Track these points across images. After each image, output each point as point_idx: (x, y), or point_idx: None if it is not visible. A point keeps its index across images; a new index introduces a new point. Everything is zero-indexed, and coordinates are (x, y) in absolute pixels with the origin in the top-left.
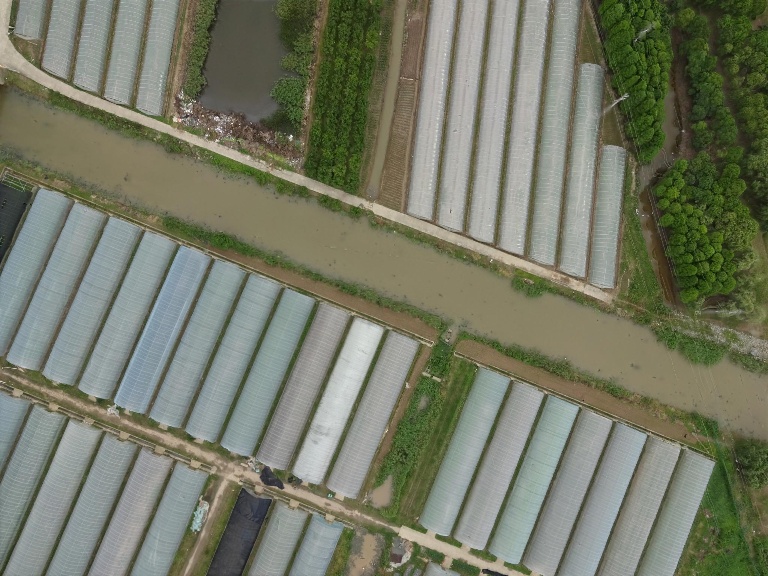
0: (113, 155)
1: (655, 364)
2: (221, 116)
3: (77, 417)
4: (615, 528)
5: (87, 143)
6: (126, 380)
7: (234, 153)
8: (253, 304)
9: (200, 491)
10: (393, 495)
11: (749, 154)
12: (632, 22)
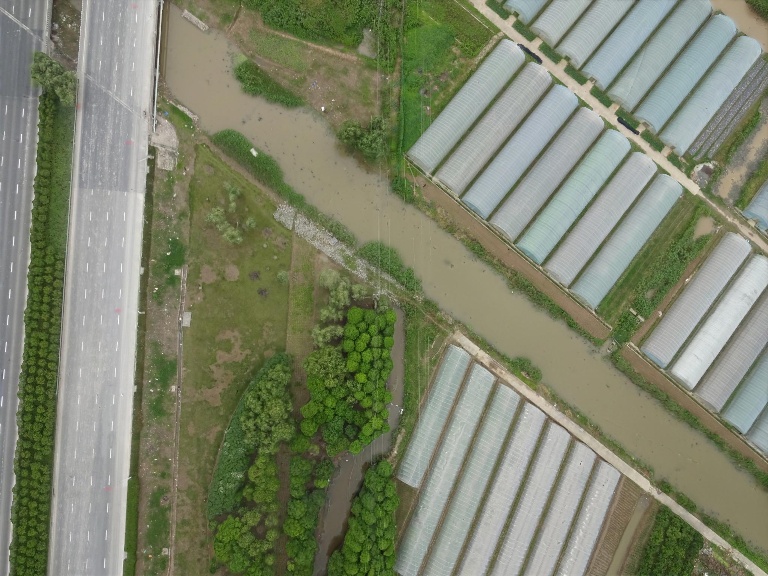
0: None
1: None
2: None
3: None
4: (515, 128)
5: None
6: None
7: (758, 574)
8: None
9: None
10: None
11: None
12: None
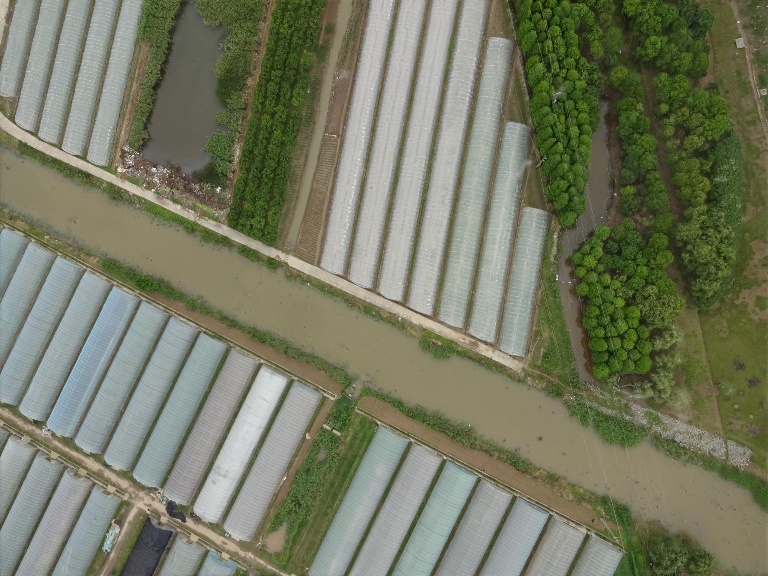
0: (67, 200)
1: (566, 440)
2: (158, 168)
3: (18, 434)
4: None
5: (46, 189)
6: (57, 406)
7: (167, 202)
8: (169, 345)
9: (112, 515)
10: (285, 542)
11: (678, 224)
12: (553, 82)
